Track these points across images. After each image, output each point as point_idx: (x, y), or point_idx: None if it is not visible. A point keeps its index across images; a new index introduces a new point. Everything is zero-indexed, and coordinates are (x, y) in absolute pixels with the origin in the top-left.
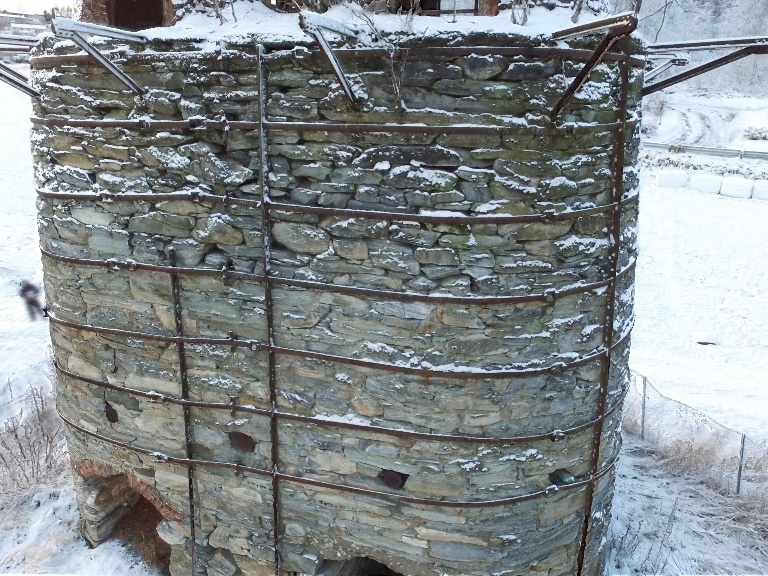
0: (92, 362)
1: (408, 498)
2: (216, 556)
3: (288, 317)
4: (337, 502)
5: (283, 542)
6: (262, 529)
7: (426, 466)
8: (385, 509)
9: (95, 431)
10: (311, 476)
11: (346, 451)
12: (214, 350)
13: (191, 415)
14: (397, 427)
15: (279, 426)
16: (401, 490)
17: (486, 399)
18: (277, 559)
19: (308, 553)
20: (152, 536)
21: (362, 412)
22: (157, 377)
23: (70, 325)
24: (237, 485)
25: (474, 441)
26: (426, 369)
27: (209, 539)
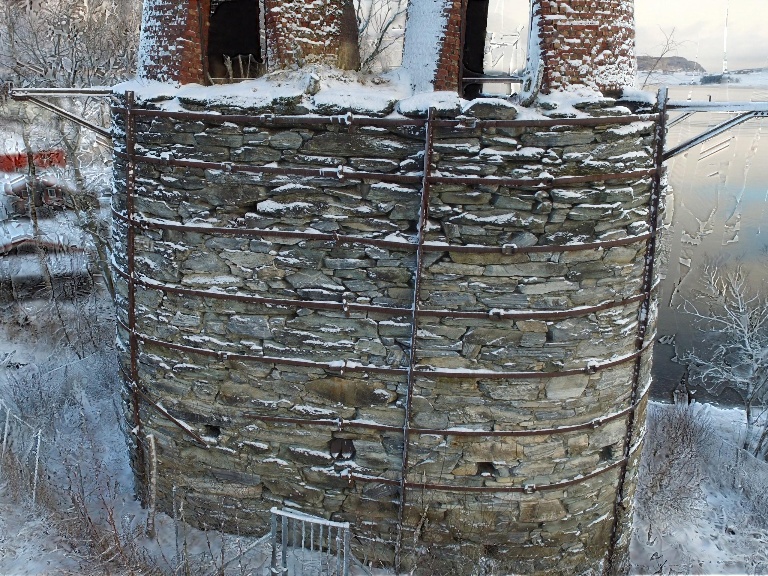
0: None
1: None
2: None
3: None
4: None
5: None
6: None
7: None
8: None
9: None
10: None
11: None
12: None
13: None
14: None
15: None
16: None
17: None
18: None
19: None
20: None
21: None
22: None
23: None
24: None
25: None
26: None
27: None
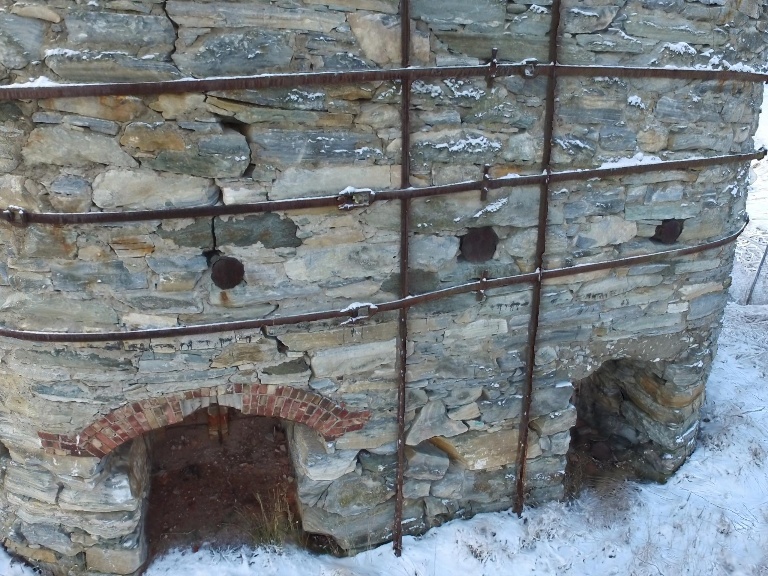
0: (186, 166)
1: (687, 249)
2: (414, 459)
3: (579, 15)
4: (608, 288)
5: (532, 380)
6: (504, 374)
7: (707, 201)
8: (657, 276)
9: (174, 324)
10: (584, 261)
11: (628, 209)
12: (461, 89)
13: (410, 219)
14: (688, 156)
15: (549, 197)
16: (677, 243)
17: (751, 107)
18: (528, 406)
19: (557, 382)
20: (228, 515)
21: (652, 147)
22: (347, 163)
23: (123, 89)
24: (475, 317)
25: (745, 158)
26: (726, 70)
27: (408, 435)
